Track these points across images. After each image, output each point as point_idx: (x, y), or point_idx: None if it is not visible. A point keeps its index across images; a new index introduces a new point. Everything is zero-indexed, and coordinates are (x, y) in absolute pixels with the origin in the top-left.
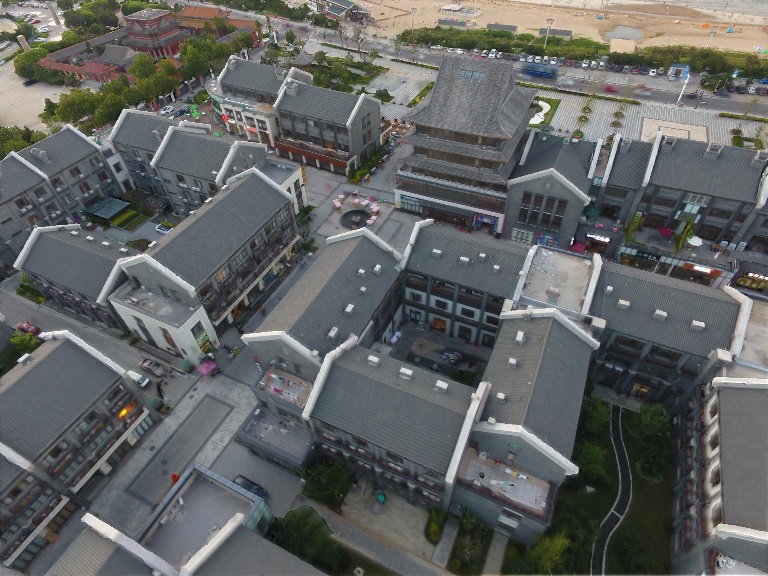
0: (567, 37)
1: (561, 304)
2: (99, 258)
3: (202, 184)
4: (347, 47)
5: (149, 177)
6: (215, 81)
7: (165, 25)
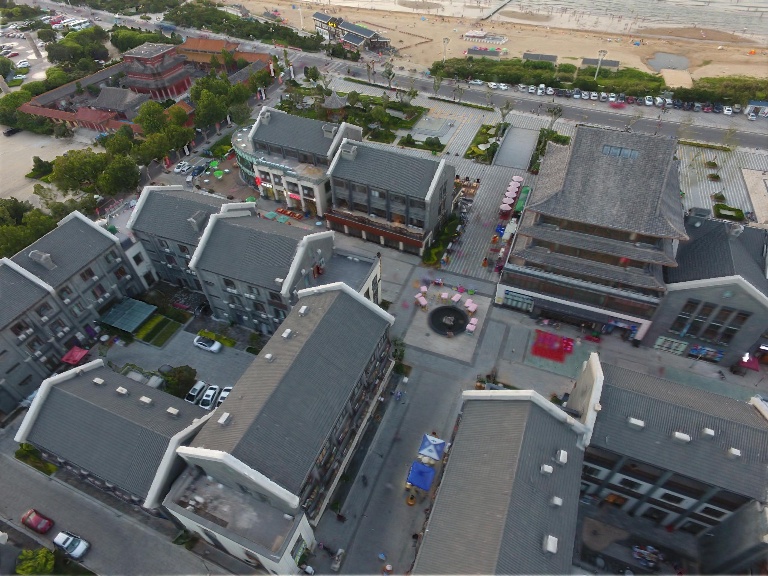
0: (614, 68)
1: None
2: (141, 431)
3: (259, 292)
4: (374, 82)
5: (178, 269)
6: (241, 134)
7: (169, 62)
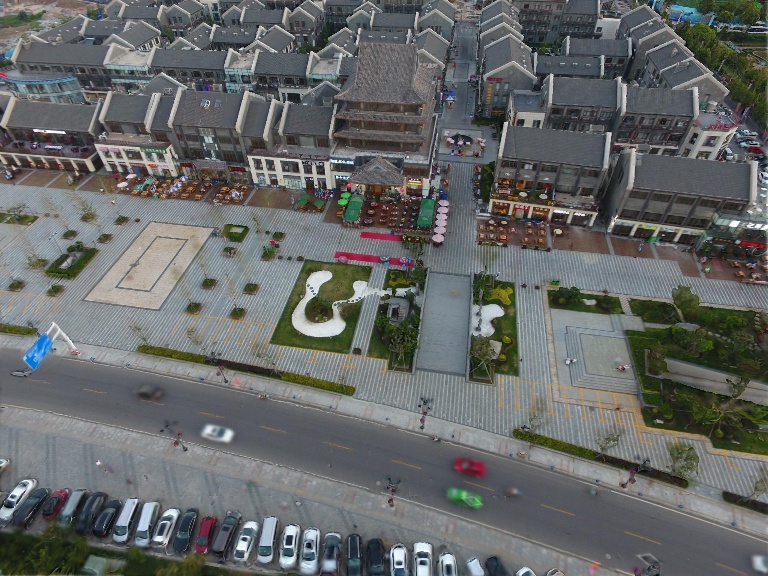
0: None
1: None
2: None
3: None
4: None
5: None
6: None
7: None
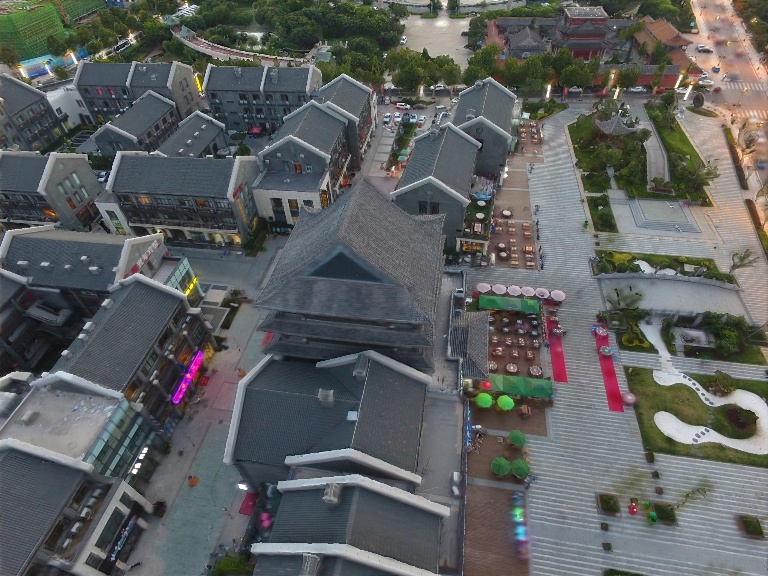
0: None
1: (14, 428)
2: None
3: None
4: None
5: None
6: None
7: (587, 29)
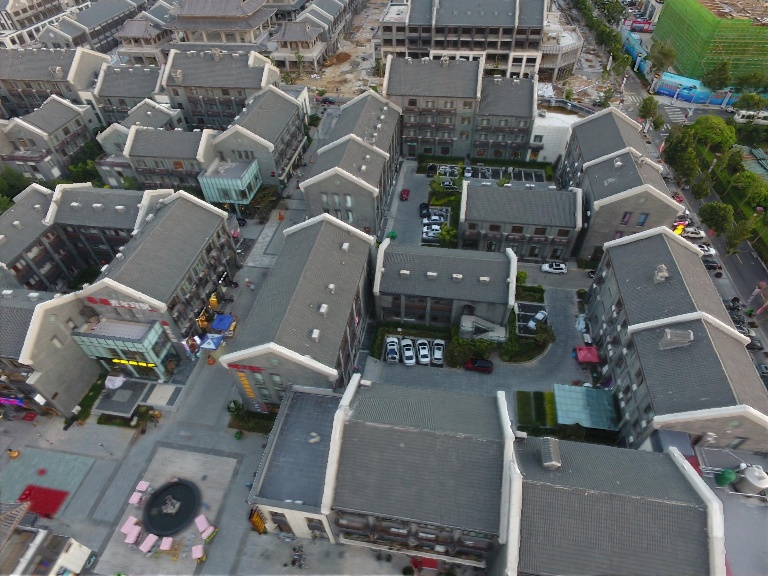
0: None
1: None
2: None
3: None
4: None
5: None
6: None
7: None
